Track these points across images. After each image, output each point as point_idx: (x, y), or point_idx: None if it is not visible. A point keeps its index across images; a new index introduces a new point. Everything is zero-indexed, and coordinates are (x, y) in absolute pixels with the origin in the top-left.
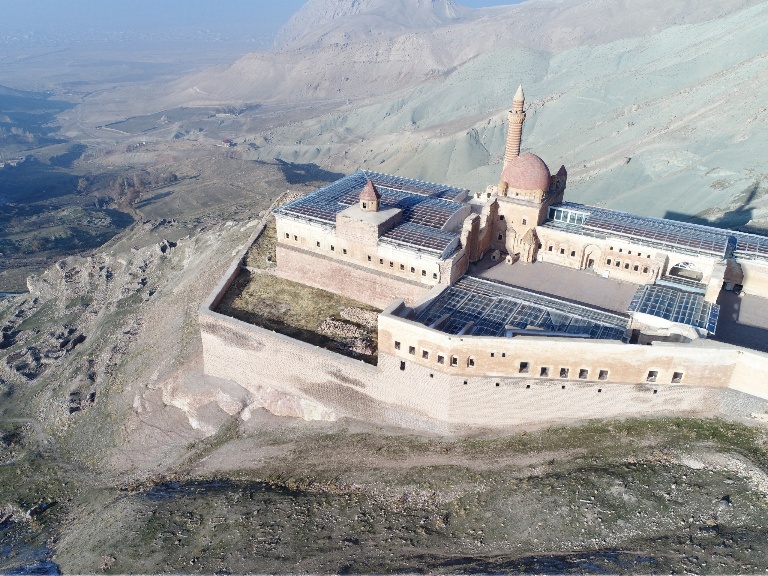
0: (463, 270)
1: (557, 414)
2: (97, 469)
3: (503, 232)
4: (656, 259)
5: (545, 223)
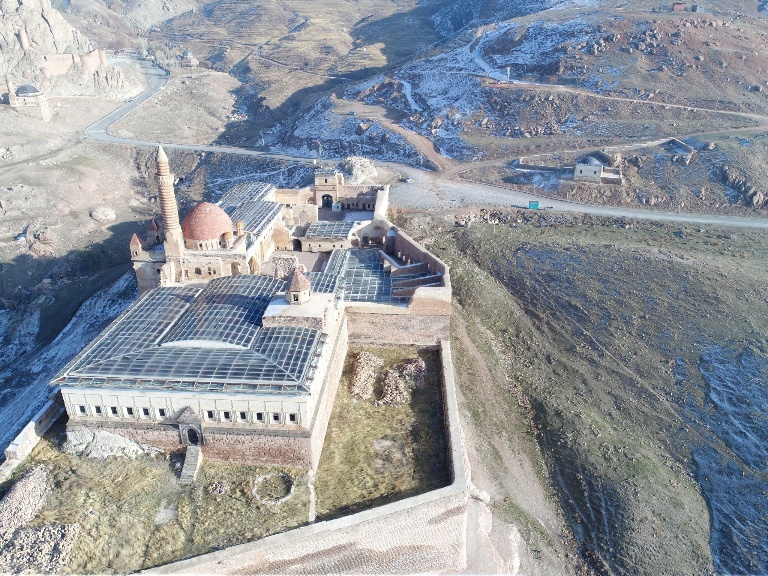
0: None
1: None
2: None
3: None
4: None
5: None
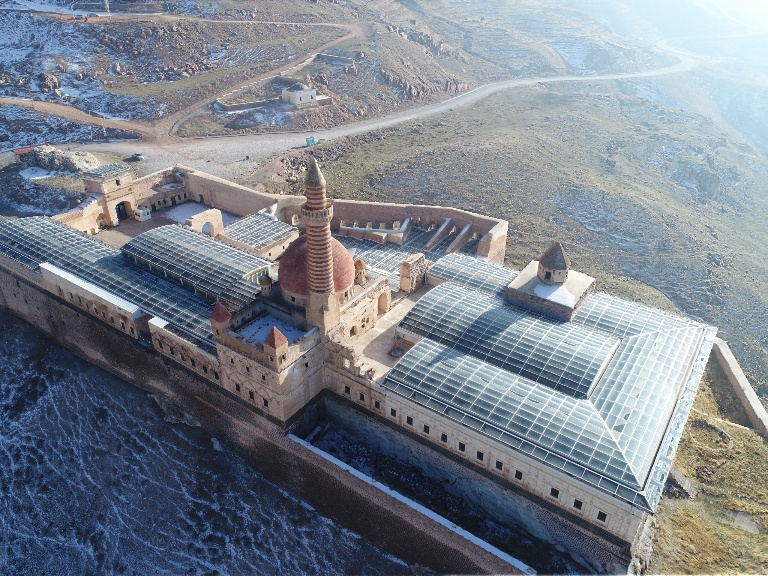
0: None
1: None
2: None
3: None
4: None
5: None
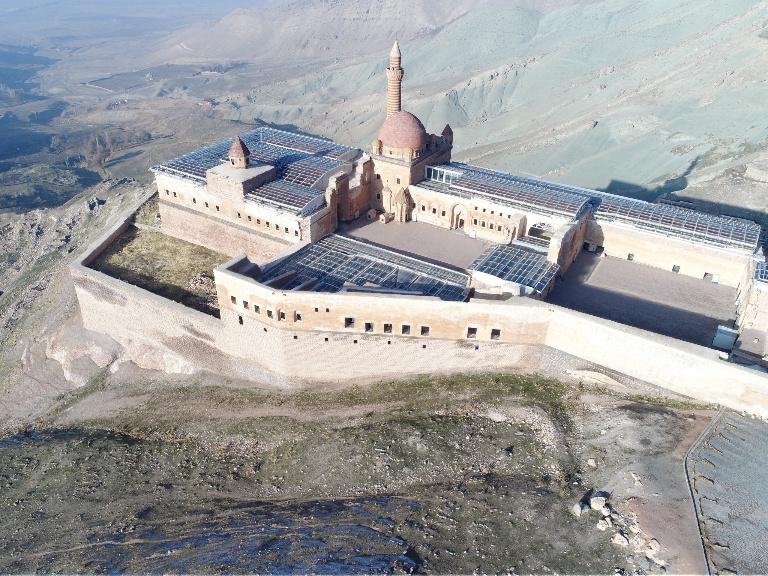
0: (331, 228)
1: (387, 369)
2: None
3: (380, 191)
4: (512, 219)
5: (420, 182)
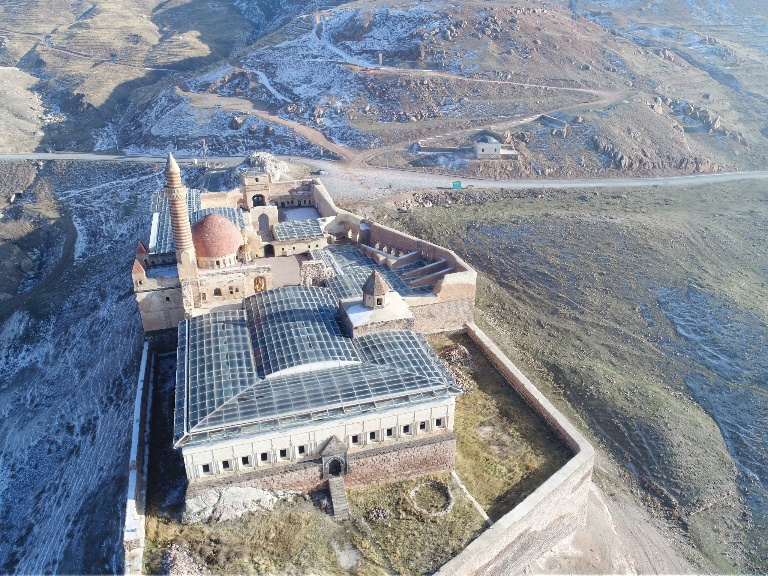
0: None
1: None
2: None
3: None
4: None
5: None
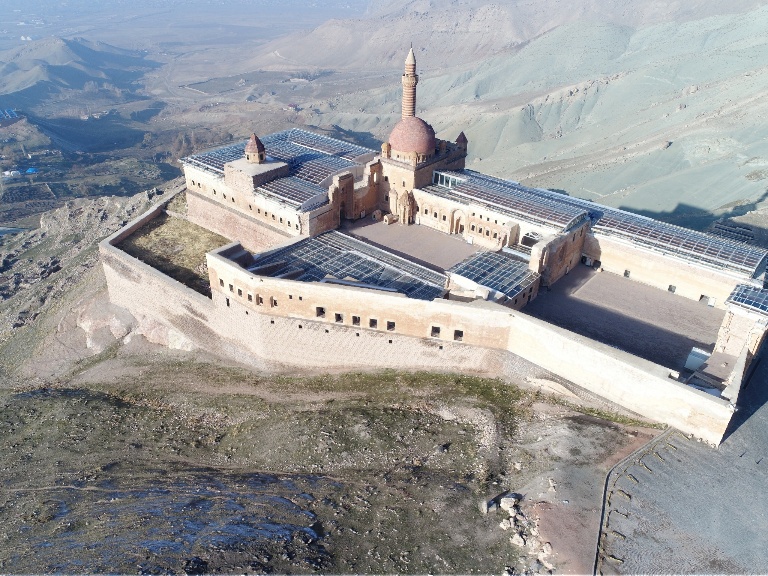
0: (332, 225)
1: (357, 360)
2: (11, 374)
3: (388, 193)
4: (504, 227)
5: (426, 187)
